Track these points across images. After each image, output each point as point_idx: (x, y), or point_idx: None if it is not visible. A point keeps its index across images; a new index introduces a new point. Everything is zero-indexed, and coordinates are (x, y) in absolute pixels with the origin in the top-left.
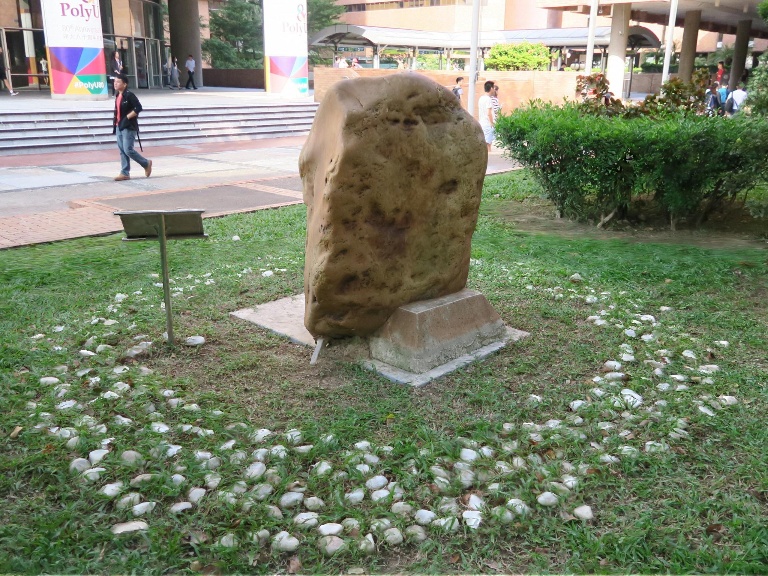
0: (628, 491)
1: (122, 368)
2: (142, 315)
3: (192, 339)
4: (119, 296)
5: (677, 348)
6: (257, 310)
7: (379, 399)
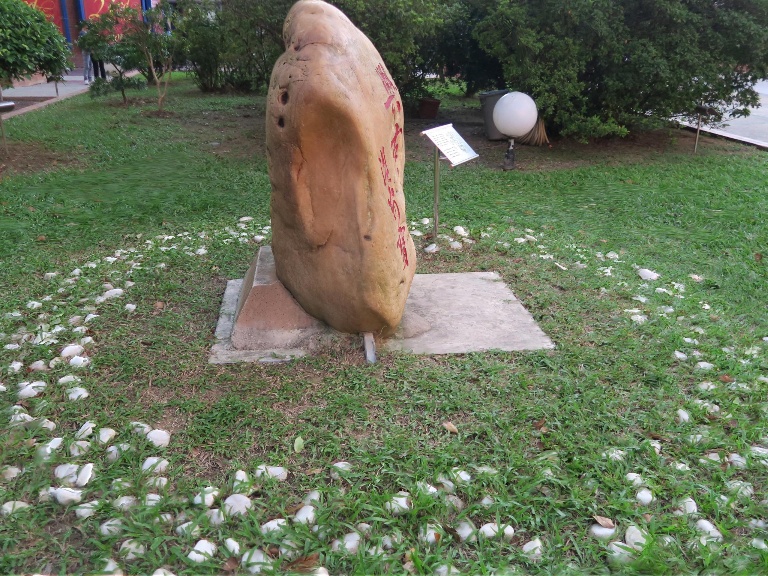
0: (28, 291)
1: (416, 232)
2: (524, 246)
3: (431, 245)
4: (609, 253)
5: (3, 437)
6: (488, 280)
7: (242, 271)
